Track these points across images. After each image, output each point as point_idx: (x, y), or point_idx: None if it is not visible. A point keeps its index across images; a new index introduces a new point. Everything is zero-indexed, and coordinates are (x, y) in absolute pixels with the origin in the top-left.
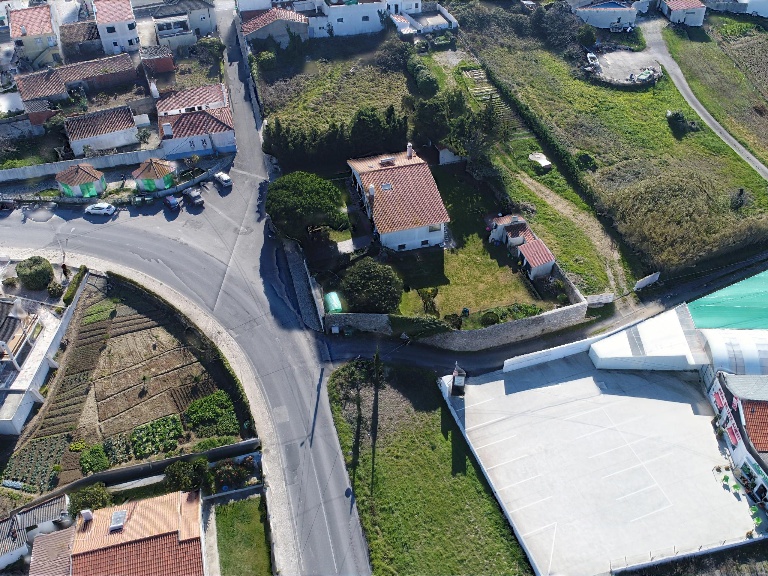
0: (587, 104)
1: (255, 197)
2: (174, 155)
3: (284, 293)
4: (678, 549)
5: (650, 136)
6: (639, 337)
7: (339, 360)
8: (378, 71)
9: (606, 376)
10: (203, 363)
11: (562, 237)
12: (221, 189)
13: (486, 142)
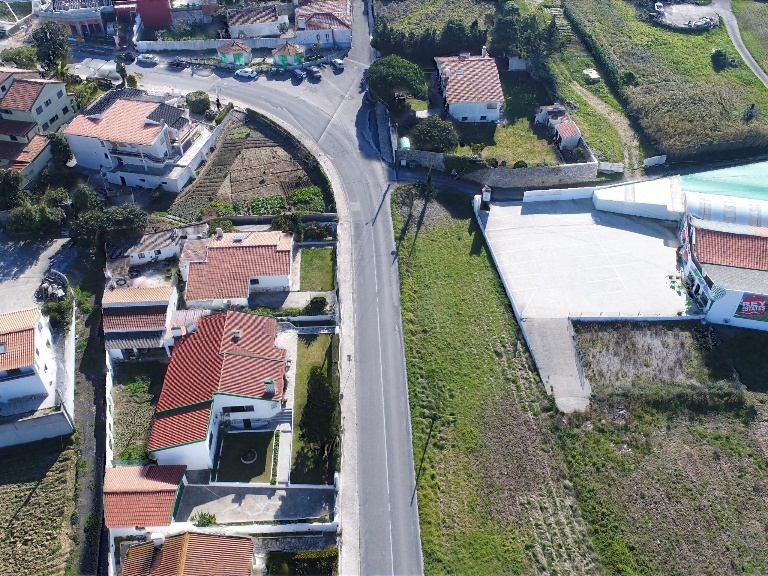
0: (644, 39)
1: (360, 78)
2: (304, 44)
3: (371, 138)
4: (622, 313)
5: (692, 67)
6: (634, 191)
7: (403, 181)
8: (474, 2)
9: (602, 214)
10: (306, 170)
11: (594, 126)
12: (335, 70)
13: (546, 51)
